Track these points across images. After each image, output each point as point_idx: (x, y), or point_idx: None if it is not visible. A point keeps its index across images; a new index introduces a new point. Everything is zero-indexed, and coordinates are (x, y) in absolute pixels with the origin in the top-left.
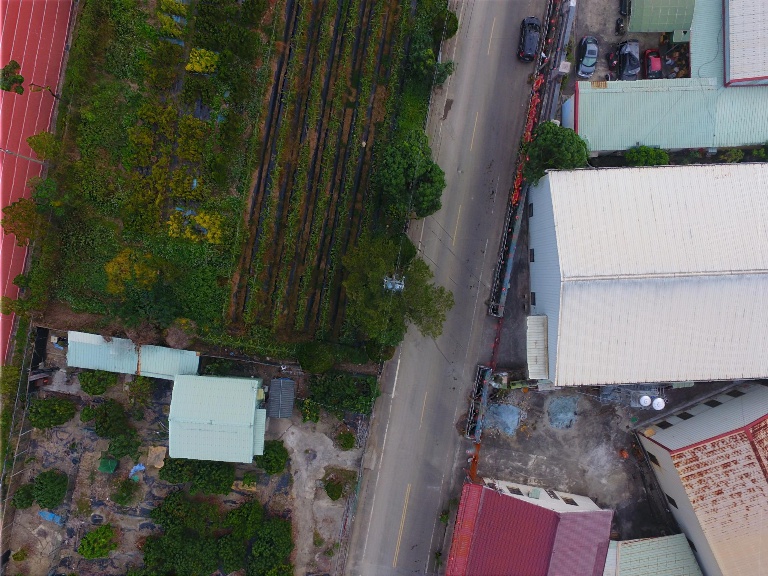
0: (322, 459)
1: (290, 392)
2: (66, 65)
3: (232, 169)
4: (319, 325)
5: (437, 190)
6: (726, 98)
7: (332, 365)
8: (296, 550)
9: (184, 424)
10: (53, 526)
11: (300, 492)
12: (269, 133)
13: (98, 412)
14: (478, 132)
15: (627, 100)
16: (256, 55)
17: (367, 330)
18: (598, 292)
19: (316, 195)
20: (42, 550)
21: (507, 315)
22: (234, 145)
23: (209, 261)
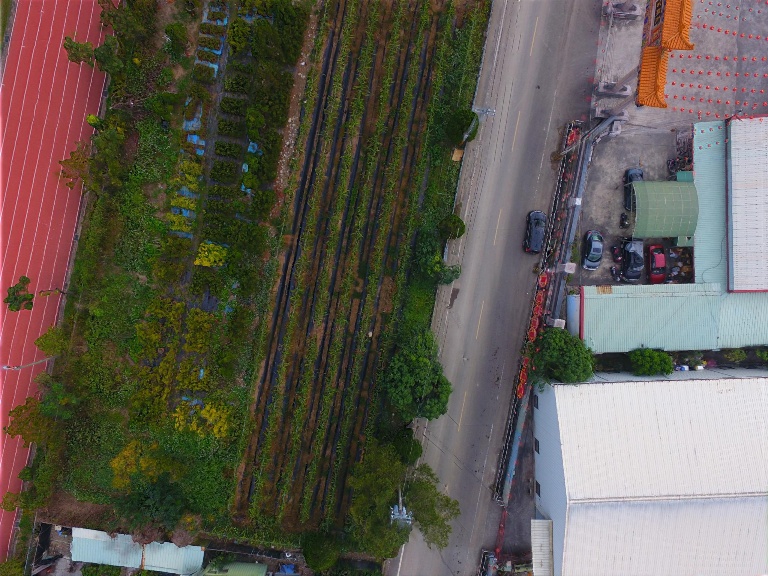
0: None
1: None
2: (75, 255)
3: (239, 361)
4: (324, 514)
5: (444, 403)
6: (729, 303)
7: (337, 559)
8: None
9: None
10: None
11: None
12: (276, 322)
13: None
14: (484, 320)
15: (632, 304)
16: (264, 248)
17: None
18: (604, 513)
19: (322, 384)
20: None
21: (512, 499)
22: (241, 339)
23: (215, 452)
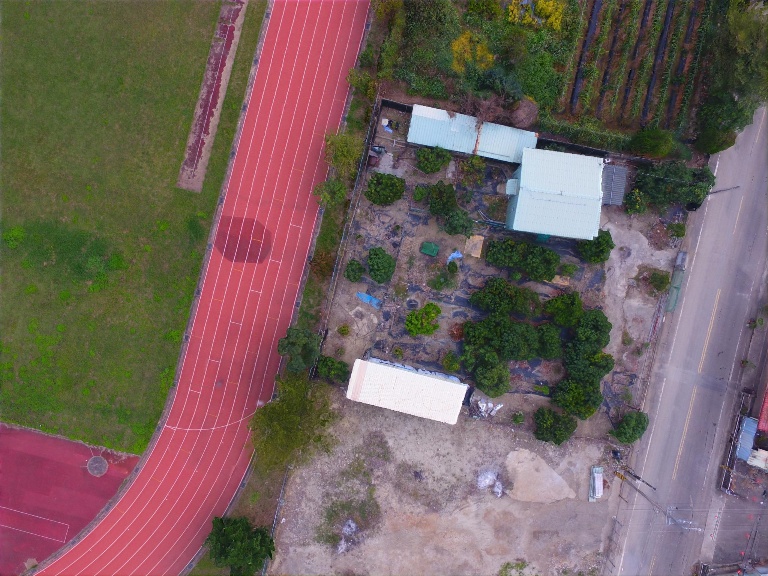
0: (636, 257)
1: (622, 179)
2: None
3: None
4: (647, 119)
5: None
6: None
7: (667, 153)
8: (604, 348)
9: (535, 193)
10: (370, 308)
11: (612, 290)
12: None
13: (432, 190)
14: None
15: None
16: None
17: (755, 86)
18: None
19: None
20: (358, 331)
21: None
22: None
23: (545, 48)
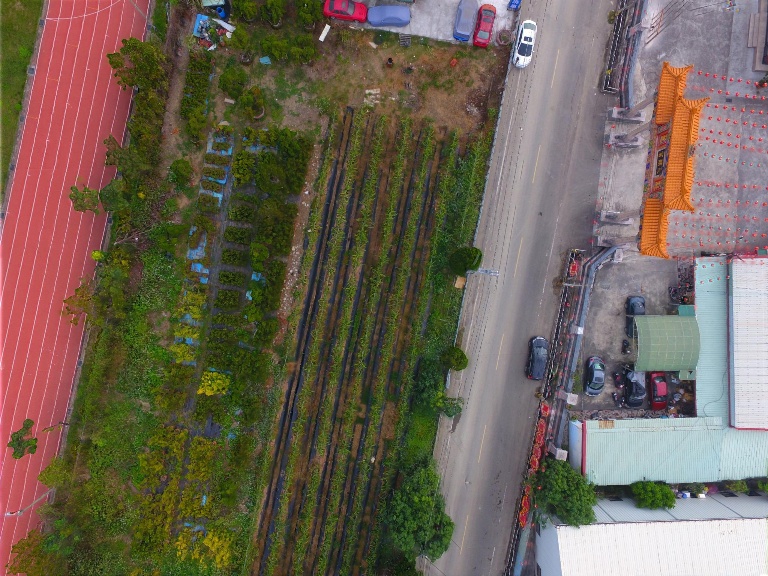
0: None
1: None
2: (78, 380)
3: (242, 489)
4: None
5: (446, 544)
6: (731, 436)
7: None
8: None
9: None
10: None
11: None
12: (279, 448)
13: None
14: (486, 444)
15: (634, 437)
16: (267, 375)
17: None
18: None
19: (325, 509)
20: None
21: None
22: (244, 467)
23: None
